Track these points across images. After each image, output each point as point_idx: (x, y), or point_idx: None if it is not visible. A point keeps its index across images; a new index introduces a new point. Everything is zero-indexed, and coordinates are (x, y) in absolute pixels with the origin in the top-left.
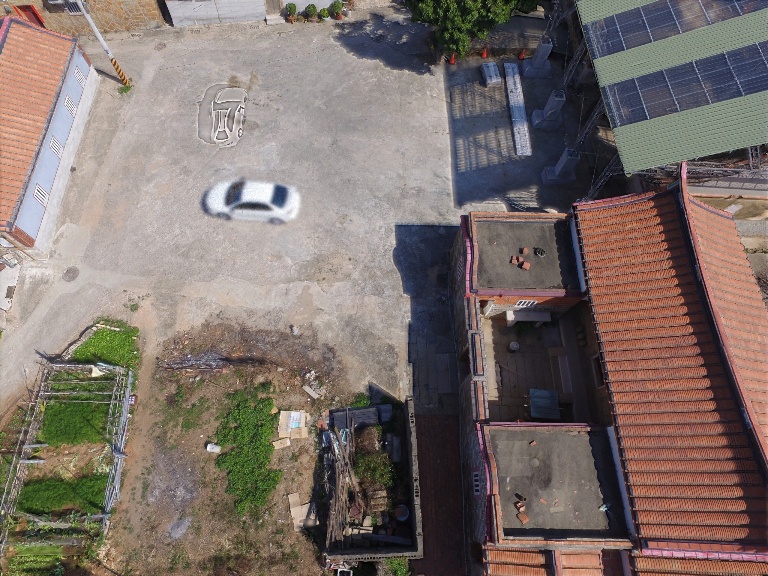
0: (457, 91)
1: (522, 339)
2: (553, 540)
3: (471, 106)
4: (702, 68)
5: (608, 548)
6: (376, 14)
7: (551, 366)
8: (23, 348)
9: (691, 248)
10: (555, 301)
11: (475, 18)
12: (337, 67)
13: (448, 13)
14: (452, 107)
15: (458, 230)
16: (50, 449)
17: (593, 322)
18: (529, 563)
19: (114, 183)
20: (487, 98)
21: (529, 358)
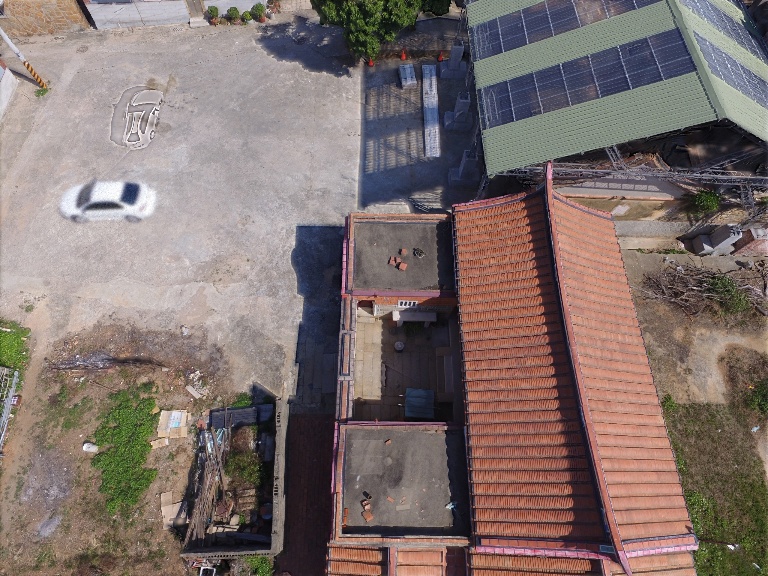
0: (373, 93)
1: (411, 339)
2: (389, 537)
3: (385, 108)
4: (567, 70)
5: (446, 545)
6: (300, 16)
7: (436, 366)
8: None
9: (551, 249)
10: (435, 301)
11: (379, 21)
12: (256, 69)
13: (351, 16)
14: (366, 109)
15: None
16: None
17: (459, 322)
18: (368, 560)
19: (21, 185)
20: (402, 100)
21: (416, 358)
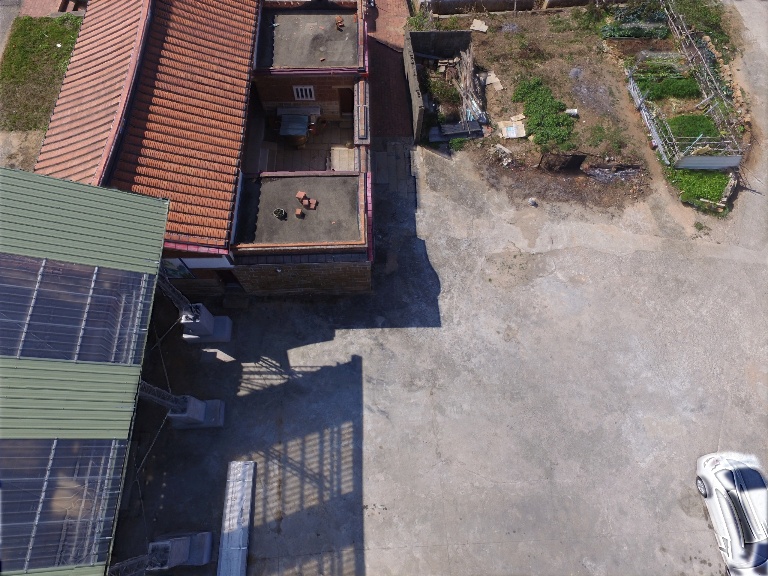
0: None
1: None
2: None
3: None
4: None
5: None
6: None
7: None
8: None
9: None
10: None
11: None
12: None
13: None
14: None
15: None
16: None
17: None
18: None
19: None
20: None
21: None
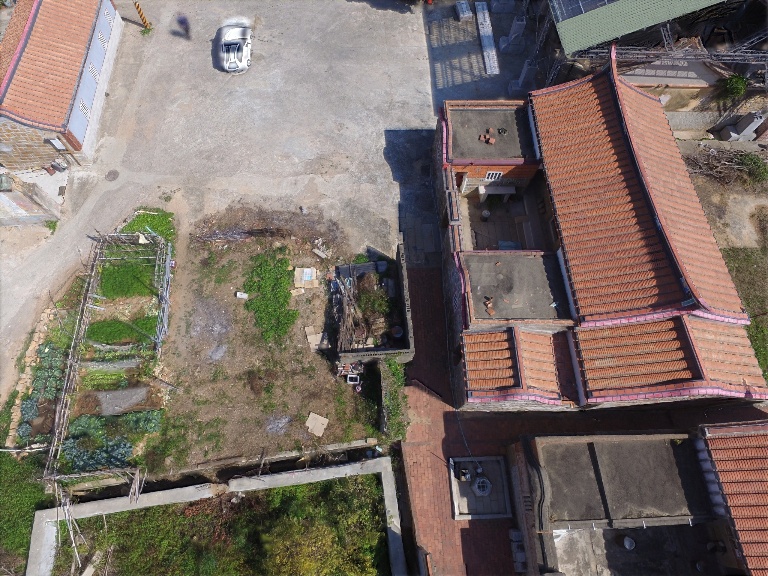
0: (435, 25)
1: (493, 212)
2: (513, 320)
3: (447, 37)
4: None
5: None
6: None
7: (517, 230)
8: (76, 234)
9: (619, 111)
10: (517, 172)
11: None
12: (330, 9)
13: None
14: (431, 38)
15: (437, 122)
16: (108, 301)
17: (545, 176)
18: (495, 340)
19: (143, 105)
20: (461, 30)
21: (499, 225)
